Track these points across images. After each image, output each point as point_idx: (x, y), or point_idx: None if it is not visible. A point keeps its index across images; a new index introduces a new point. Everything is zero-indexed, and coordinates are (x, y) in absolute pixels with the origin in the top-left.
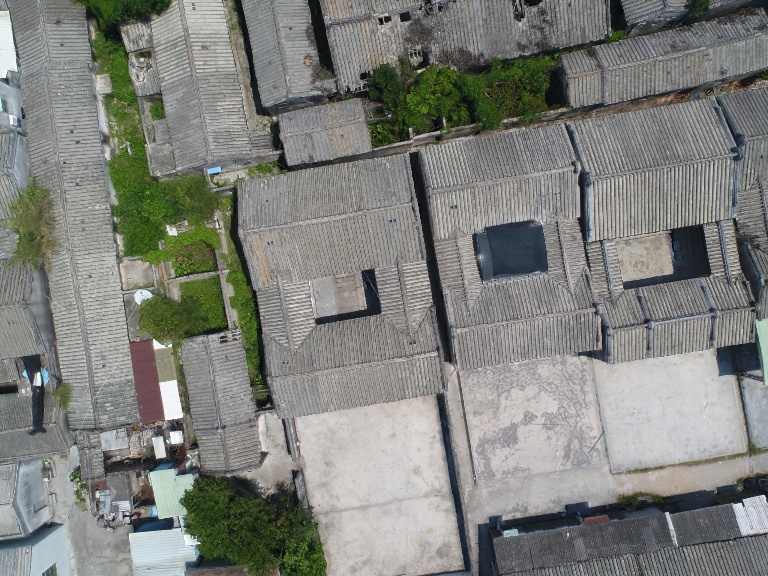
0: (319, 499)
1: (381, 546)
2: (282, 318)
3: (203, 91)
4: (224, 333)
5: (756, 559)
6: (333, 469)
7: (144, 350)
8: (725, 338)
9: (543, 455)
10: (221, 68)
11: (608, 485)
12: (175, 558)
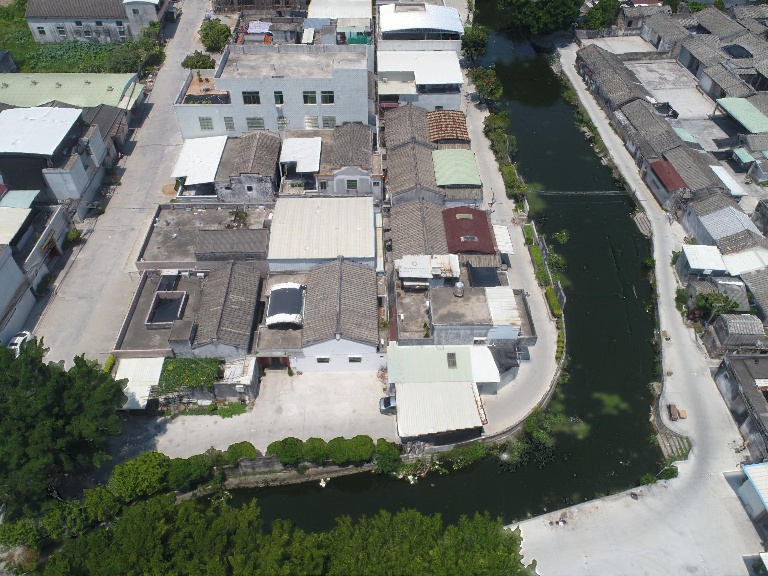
0: None
1: None
2: None
3: (755, 8)
4: None
5: None
6: (621, 41)
7: (657, 2)
8: None
9: None
10: (765, 14)
11: None
12: None
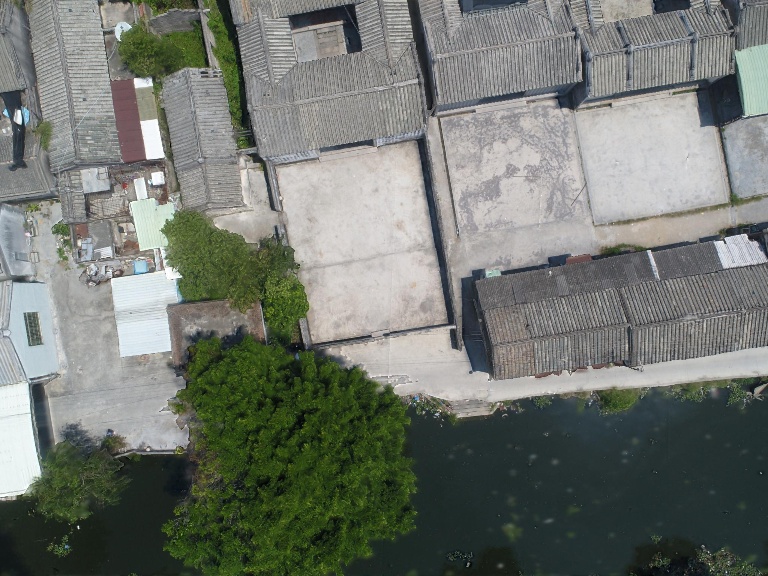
0: (302, 255)
1: (364, 301)
2: (263, 52)
3: None
4: (205, 69)
5: (738, 287)
6: (316, 225)
7: (125, 88)
8: (705, 68)
9: (526, 208)
10: None
11: (591, 237)
12: (157, 301)
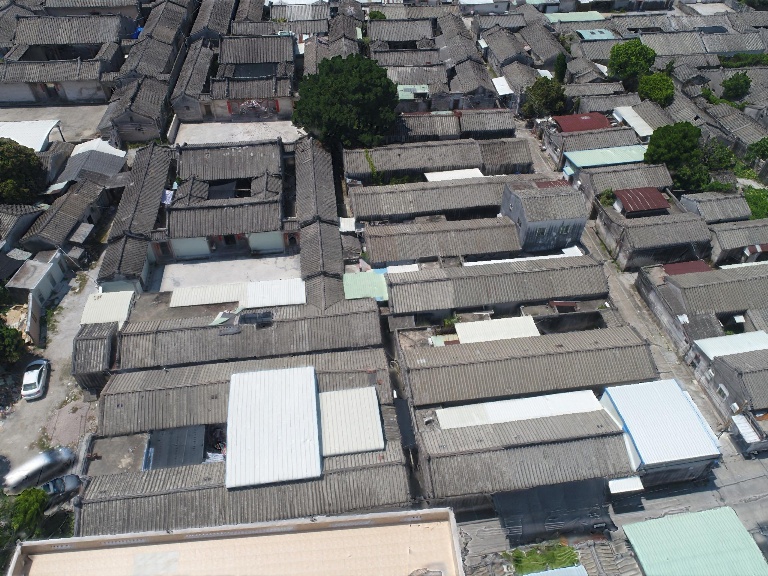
0: None
1: None
2: None
3: None
4: None
5: None
6: None
7: None
8: None
9: None
10: None
11: None
12: None
